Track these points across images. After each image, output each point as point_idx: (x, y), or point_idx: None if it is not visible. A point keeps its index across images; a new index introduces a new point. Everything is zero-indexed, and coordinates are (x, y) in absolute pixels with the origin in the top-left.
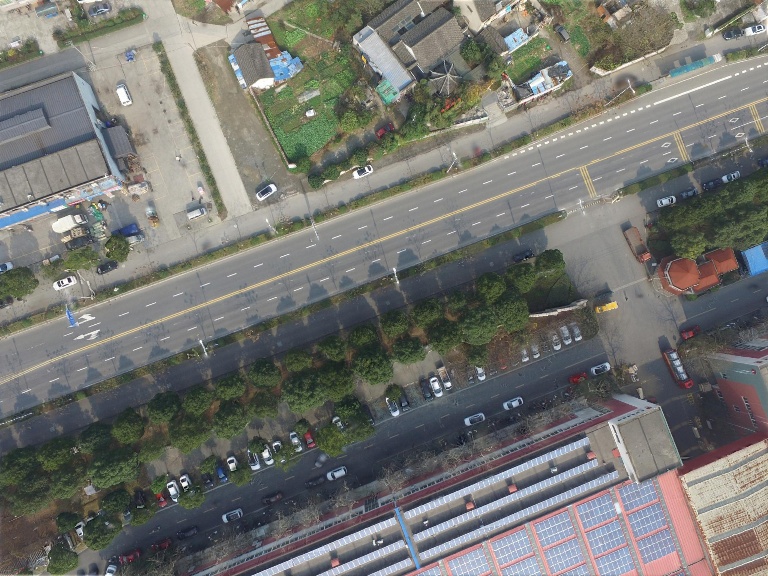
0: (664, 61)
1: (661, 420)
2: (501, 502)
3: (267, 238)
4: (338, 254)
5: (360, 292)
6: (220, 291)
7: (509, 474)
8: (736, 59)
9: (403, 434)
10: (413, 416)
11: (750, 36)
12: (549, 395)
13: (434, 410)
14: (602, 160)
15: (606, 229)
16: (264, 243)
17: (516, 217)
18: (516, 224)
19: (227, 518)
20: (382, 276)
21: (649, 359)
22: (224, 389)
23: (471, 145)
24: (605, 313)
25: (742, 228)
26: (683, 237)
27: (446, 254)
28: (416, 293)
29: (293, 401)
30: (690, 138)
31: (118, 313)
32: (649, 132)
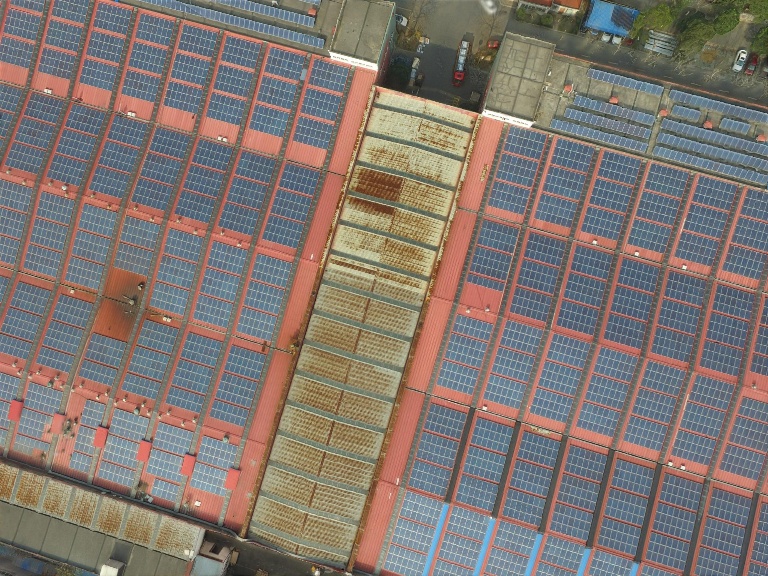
0: None
1: (388, 17)
2: None
3: None
4: None
5: None
6: None
7: None
8: None
9: None
10: None
11: None
12: None
13: None
14: None
15: None
16: None
17: None
18: None
19: None
20: None
21: (445, 43)
22: None
23: None
24: None
25: None
26: None
27: None
28: None
29: None
30: None
31: None
32: None
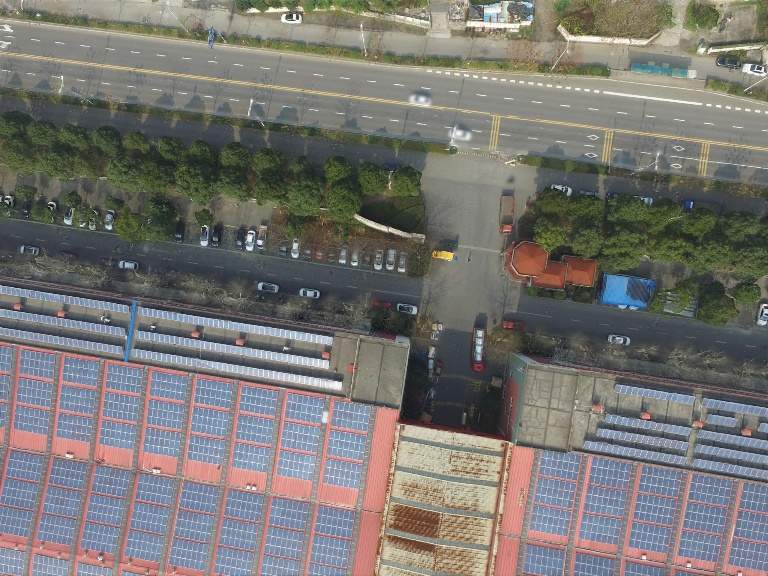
0: (639, 56)
1: (404, 358)
2: (225, 348)
3: (179, 34)
4: (232, 80)
5: (231, 122)
6: (119, 61)
7: (245, 329)
8: (715, 88)
9: (202, 265)
10: (218, 255)
11: (746, 74)
12: (347, 305)
13: (239, 260)
14: (520, 119)
15: (487, 186)
16: (176, 39)
17: (407, 130)
18: (404, 136)
19: (24, 249)
20: (258, 119)
21: (459, 327)
22: (63, 130)
23: (403, 43)
24: (441, 262)
25: (611, 245)
26: (544, 221)
27: (324, 129)
28: (279, 150)
29: (109, 169)
30: (622, 143)
31: (32, 37)
32: (583, 116)
